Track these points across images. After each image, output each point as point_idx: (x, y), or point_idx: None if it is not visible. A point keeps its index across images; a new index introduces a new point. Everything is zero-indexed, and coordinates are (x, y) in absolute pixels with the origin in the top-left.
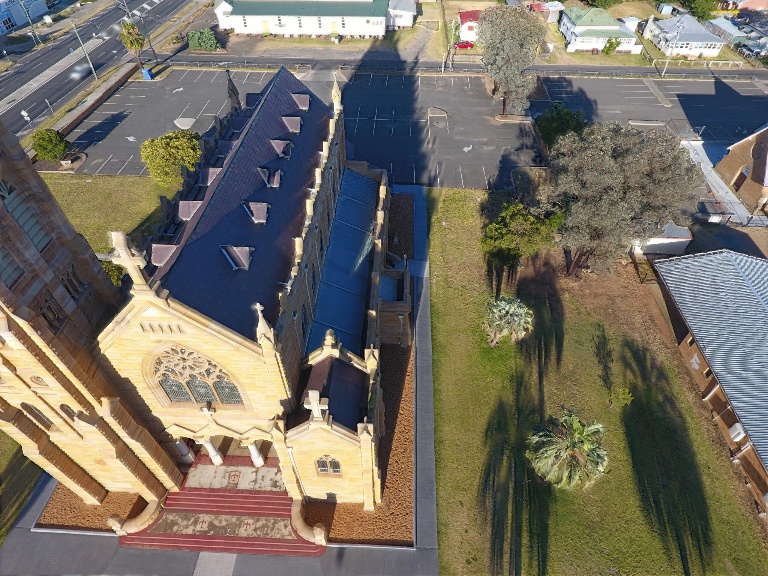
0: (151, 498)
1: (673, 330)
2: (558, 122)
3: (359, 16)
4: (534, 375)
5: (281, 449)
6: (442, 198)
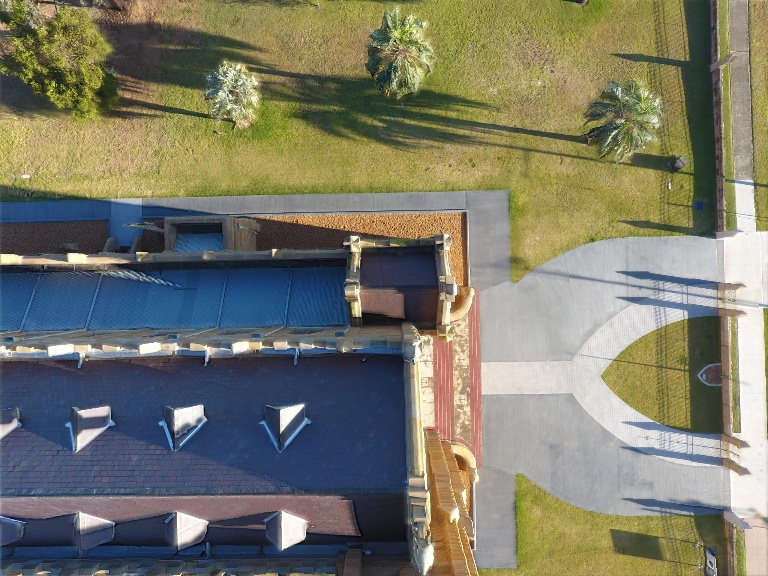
0: None
1: None
2: None
3: None
4: (285, 82)
5: None
6: None
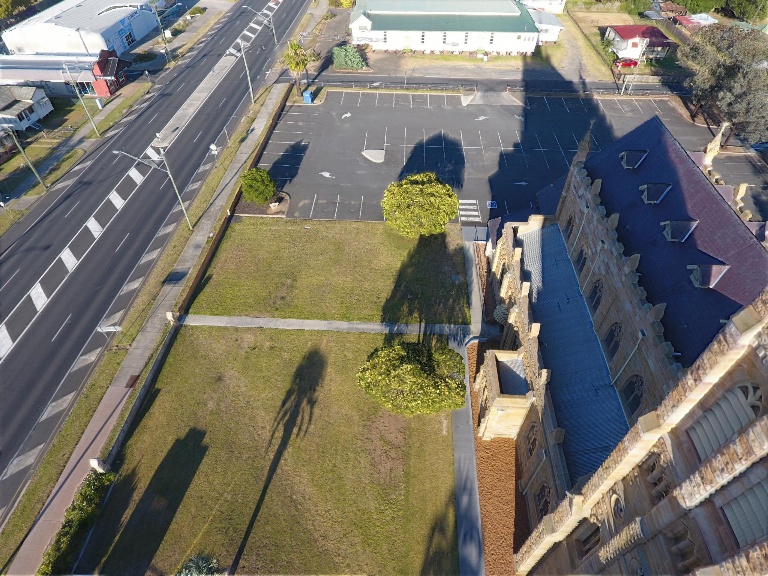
0: None
1: None
2: None
3: (511, 31)
4: None
5: None
6: None
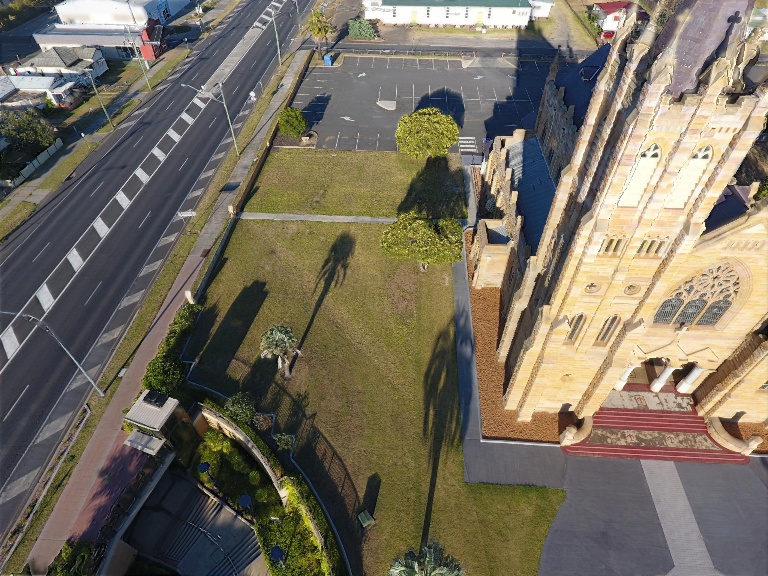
0: (588, 414)
1: None
2: None
3: (507, 7)
4: None
5: (767, 360)
6: None
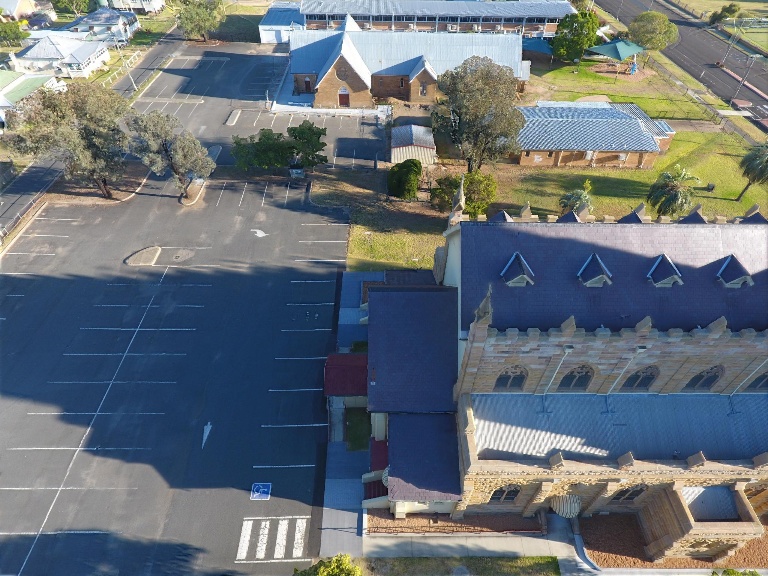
0: None
1: (506, 164)
2: (291, 141)
3: None
4: None
5: None
6: (369, 259)
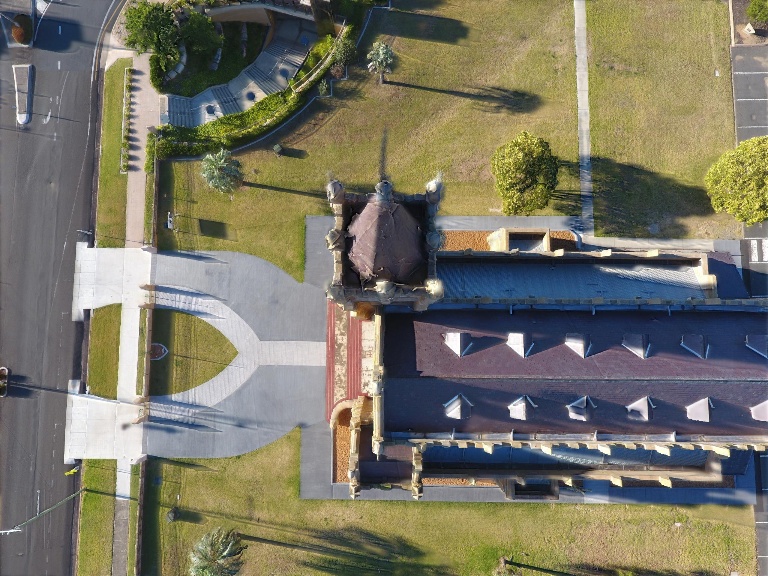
0: None
1: None
2: None
3: None
4: None
5: None
6: (731, 525)
